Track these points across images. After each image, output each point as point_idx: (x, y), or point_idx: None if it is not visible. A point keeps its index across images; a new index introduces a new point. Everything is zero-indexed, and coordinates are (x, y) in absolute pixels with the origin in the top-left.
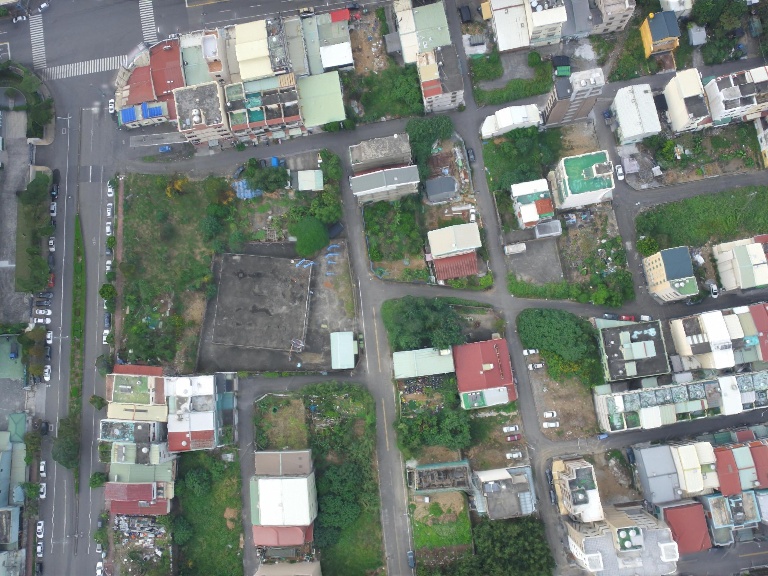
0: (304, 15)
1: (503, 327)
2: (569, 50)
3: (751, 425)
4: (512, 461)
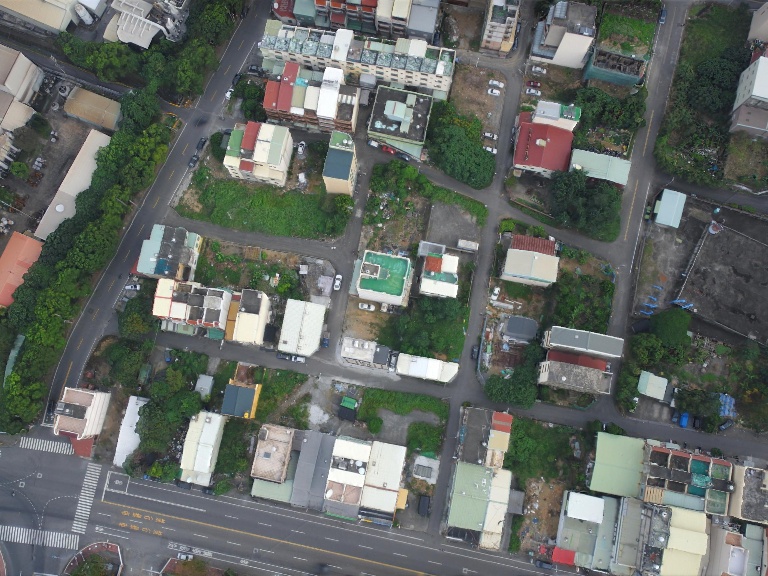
0: (605, 573)
1: (510, 176)
2: (333, 424)
3: (326, 28)
4: (542, 67)
